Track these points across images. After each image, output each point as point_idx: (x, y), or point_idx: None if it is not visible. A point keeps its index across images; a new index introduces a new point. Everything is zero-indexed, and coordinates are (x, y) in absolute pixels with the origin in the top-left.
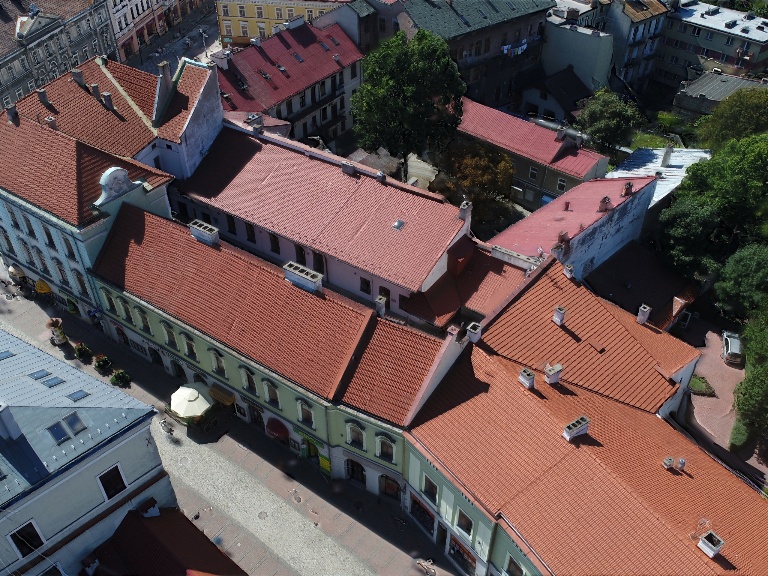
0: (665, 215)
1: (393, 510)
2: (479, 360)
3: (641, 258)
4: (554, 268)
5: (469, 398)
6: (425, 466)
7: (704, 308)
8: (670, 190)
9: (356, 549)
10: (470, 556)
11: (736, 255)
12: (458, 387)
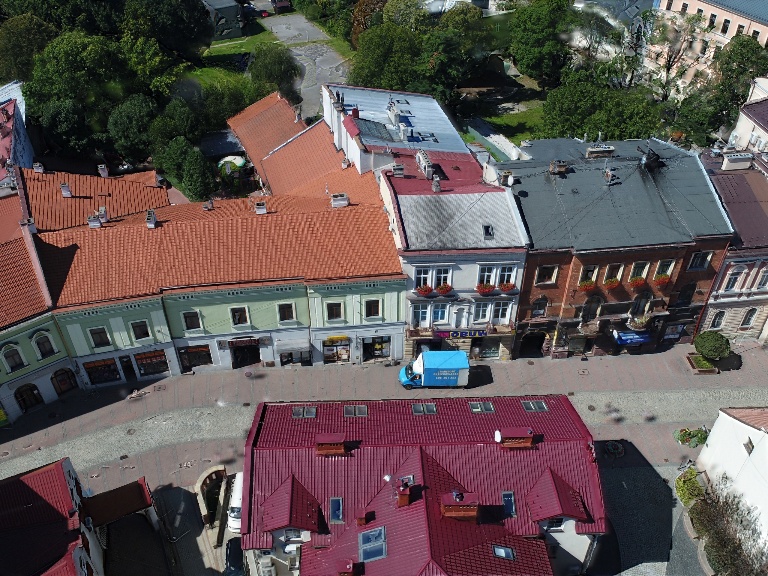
0: (45, 121)
1: (79, 396)
2: (52, 238)
3: (52, 164)
4: (26, 173)
5: (72, 260)
6: (86, 322)
7: (118, 172)
8: (24, 113)
9: (84, 431)
10: (157, 355)
11: (111, 121)
12: (57, 261)
